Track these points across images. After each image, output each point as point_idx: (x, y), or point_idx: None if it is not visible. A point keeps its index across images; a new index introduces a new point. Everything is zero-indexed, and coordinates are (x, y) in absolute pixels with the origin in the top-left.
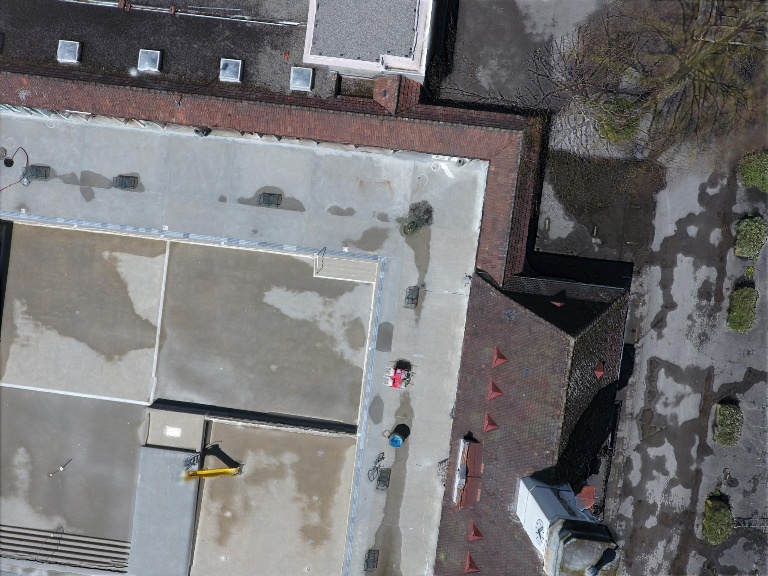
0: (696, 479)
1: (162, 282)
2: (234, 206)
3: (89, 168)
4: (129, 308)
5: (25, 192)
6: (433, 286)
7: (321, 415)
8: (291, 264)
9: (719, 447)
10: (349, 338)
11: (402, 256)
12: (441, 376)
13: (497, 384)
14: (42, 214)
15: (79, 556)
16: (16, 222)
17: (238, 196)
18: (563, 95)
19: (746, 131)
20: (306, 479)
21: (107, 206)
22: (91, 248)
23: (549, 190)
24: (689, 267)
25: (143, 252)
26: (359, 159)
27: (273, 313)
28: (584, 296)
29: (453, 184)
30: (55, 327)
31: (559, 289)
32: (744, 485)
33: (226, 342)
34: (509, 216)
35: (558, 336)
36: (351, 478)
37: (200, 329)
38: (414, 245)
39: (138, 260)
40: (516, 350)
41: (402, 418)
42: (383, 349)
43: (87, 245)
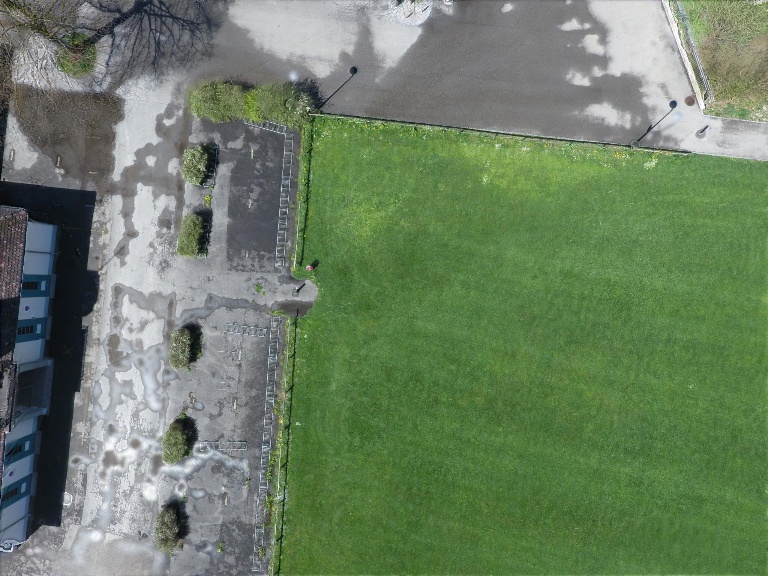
0: (163, 403)
1: None
2: None
3: None
4: None
5: None
6: None
7: None
8: None
9: (183, 371)
10: None
11: None
12: None
13: None
14: None
15: None
16: None
17: None
18: (22, 30)
19: (202, 63)
20: None
21: None
22: None
23: (13, 122)
24: (149, 196)
25: None
26: None
27: None
28: None
29: None
30: None
31: None
32: (210, 409)
33: None
34: None
35: None
36: None
37: None
38: None
39: None
40: None
41: None
42: None
43: None
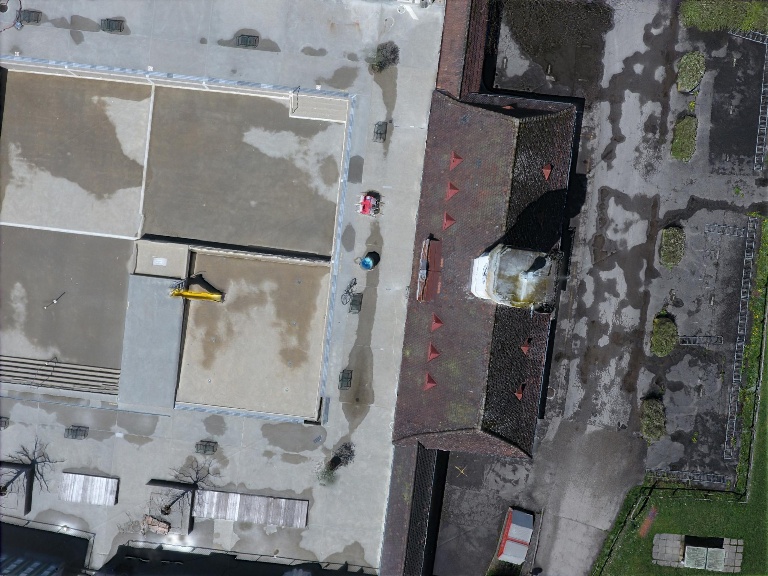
0: (644, 300)
1: (148, 123)
2: (214, 47)
3: (78, 13)
4: (117, 149)
5: (19, 36)
6: (400, 122)
7: (298, 248)
8: (268, 106)
9: (665, 270)
10: (323, 174)
11: (371, 93)
12: (408, 205)
13: (454, 184)
14: (35, 56)
15: (72, 380)
16: (10, 70)
17: (218, 38)
18: None
19: None
20: (284, 306)
21: (96, 48)
22: (81, 93)
23: (506, 31)
24: (636, 102)
25: (130, 96)
26: (330, 3)
27: (252, 152)
28: (534, 107)
29: (417, 25)
30: (48, 168)
31: (511, 102)
32: (689, 305)
33: (208, 180)
34: (465, 34)
35: (506, 122)
36: (326, 304)
37: (184, 168)
38: (382, 83)
39: (125, 104)
40: (470, 148)
41: (372, 246)
42: (354, 181)
43: (77, 90)
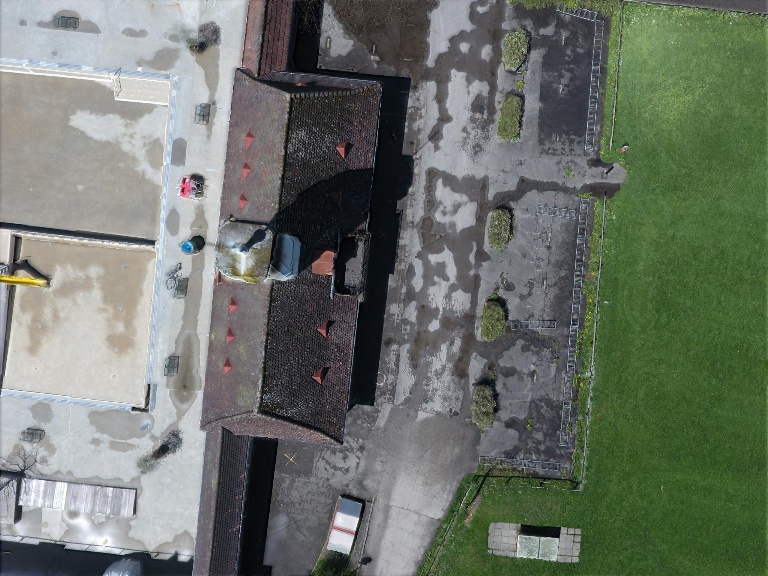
0: (475, 284)
1: None
2: (34, 30)
3: None
4: None
5: None
6: (223, 103)
7: (125, 232)
8: (94, 88)
9: (495, 253)
10: (150, 158)
11: (193, 75)
12: None
13: (248, 163)
14: None
15: None
16: None
17: (37, 20)
18: None
19: None
20: (110, 291)
21: None
22: None
23: (329, 10)
24: (463, 82)
25: None
26: None
27: (78, 136)
28: (334, 85)
29: (239, 5)
30: None
31: (312, 80)
32: (520, 289)
33: (35, 164)
34: (263, 11)
35: (281, 98)
36: (152, 289)
37: (10, 152)
38: (204, 64)
39: None
40: (259, 125)
41: (197, 230)
42: (177, 164)
43: None
